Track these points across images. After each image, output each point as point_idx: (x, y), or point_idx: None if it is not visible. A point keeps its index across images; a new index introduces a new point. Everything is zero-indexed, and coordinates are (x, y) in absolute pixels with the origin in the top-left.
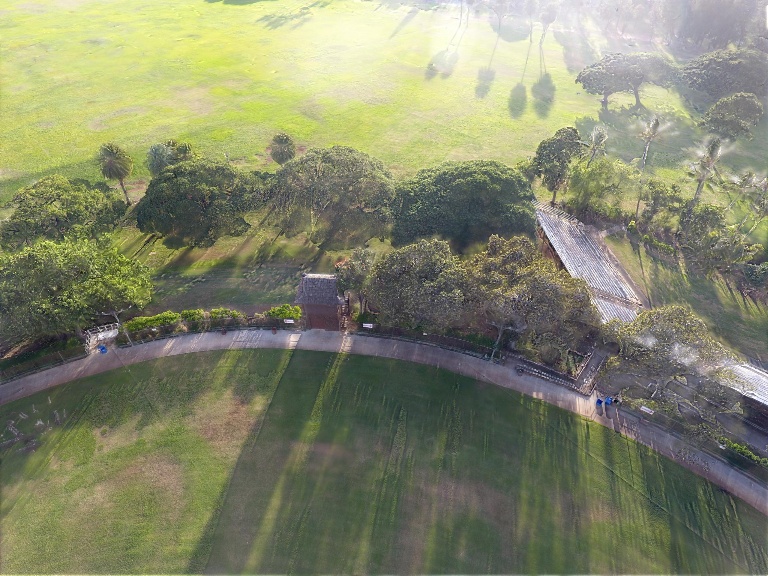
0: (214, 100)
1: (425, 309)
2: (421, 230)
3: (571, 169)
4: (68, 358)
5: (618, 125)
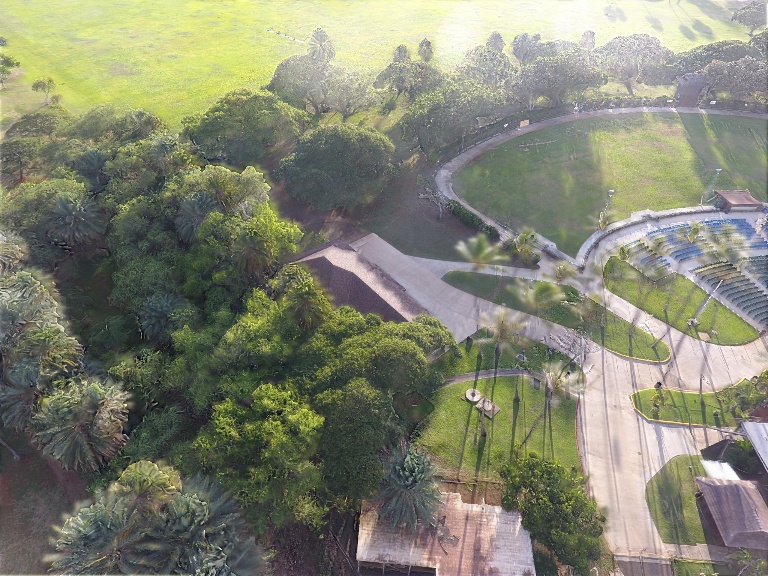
0: (476, 30)
1: (762, 81)
2: None
3: None
4: (567, 113)
5: None
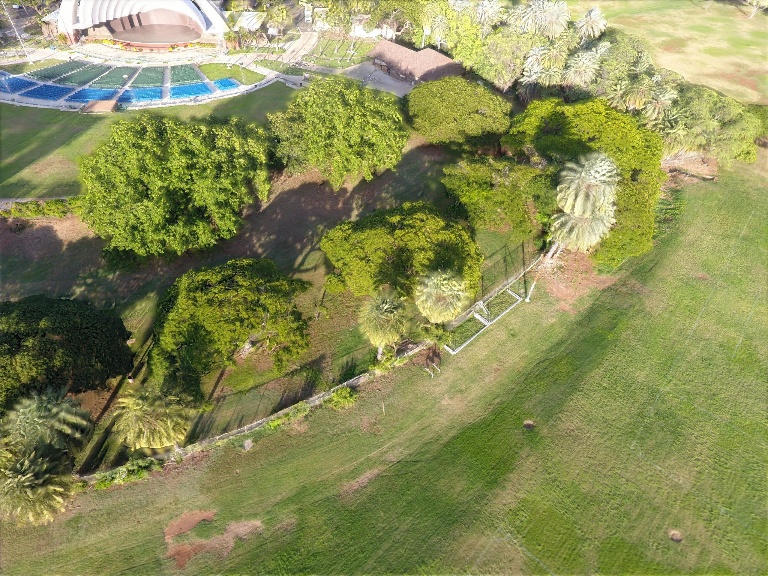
0: None
1: None
2: None
3: None
4: None
5: None
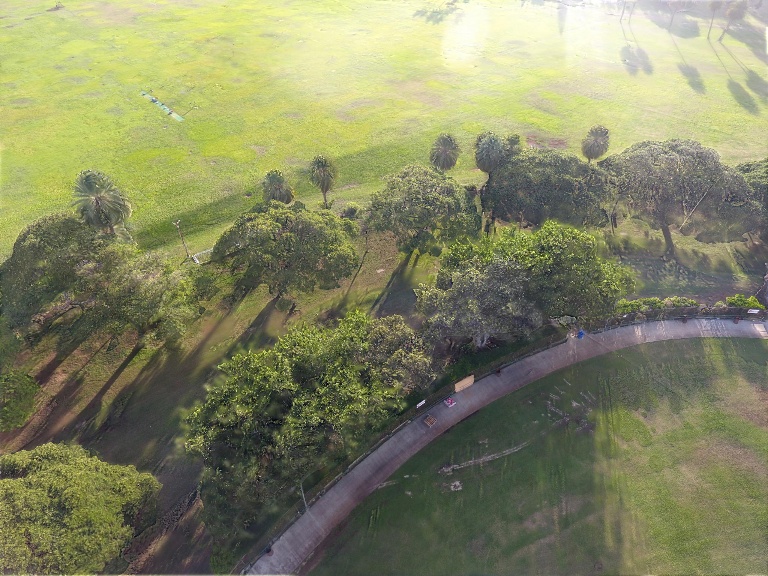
0: (438, 93)
1: None
2: None
3: None
4: (553, 342)
5: None
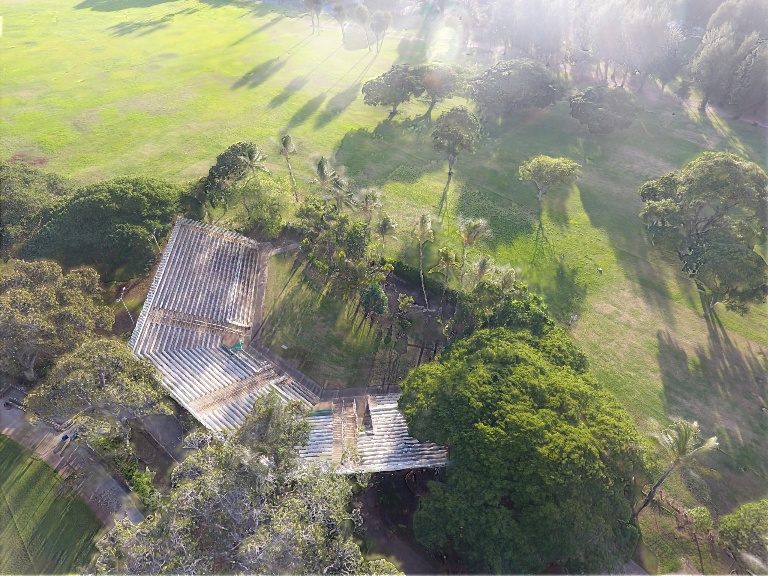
0: None
1: None
2: (33, 251)
3: (230, 186)
4: None
5: (387, 137)
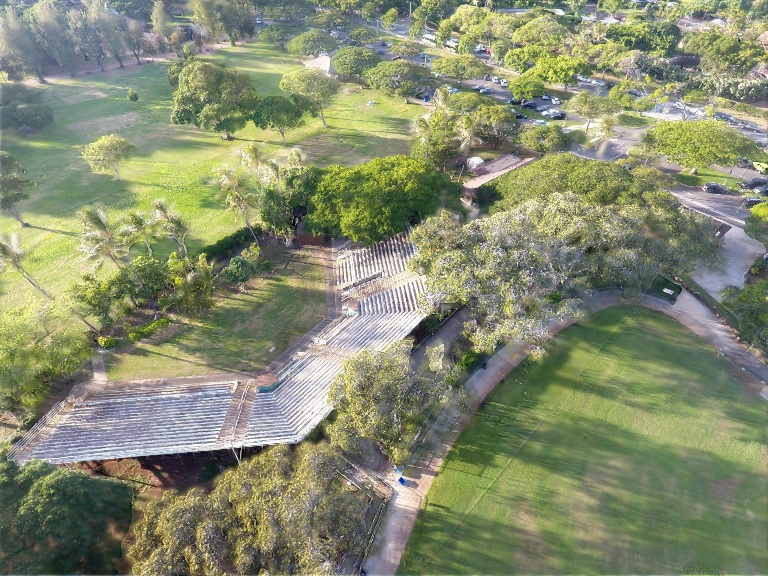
0: None
1: None
2: None
3: None
4: None
5: None
